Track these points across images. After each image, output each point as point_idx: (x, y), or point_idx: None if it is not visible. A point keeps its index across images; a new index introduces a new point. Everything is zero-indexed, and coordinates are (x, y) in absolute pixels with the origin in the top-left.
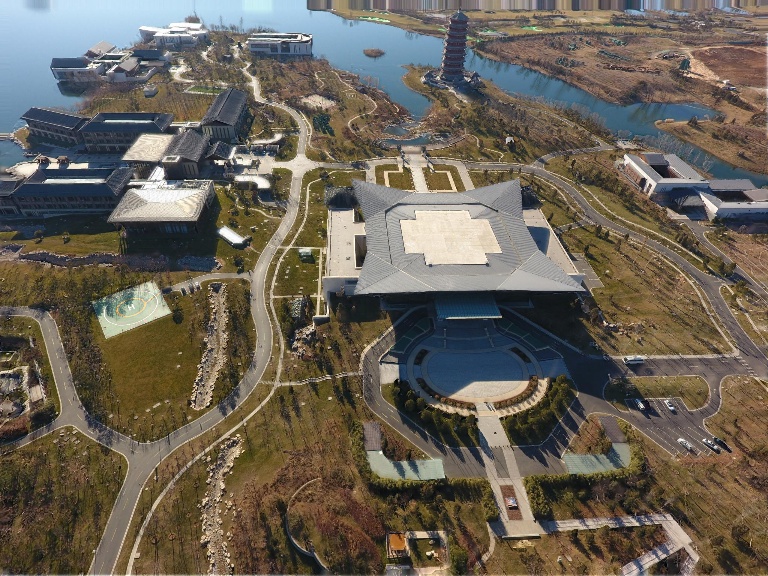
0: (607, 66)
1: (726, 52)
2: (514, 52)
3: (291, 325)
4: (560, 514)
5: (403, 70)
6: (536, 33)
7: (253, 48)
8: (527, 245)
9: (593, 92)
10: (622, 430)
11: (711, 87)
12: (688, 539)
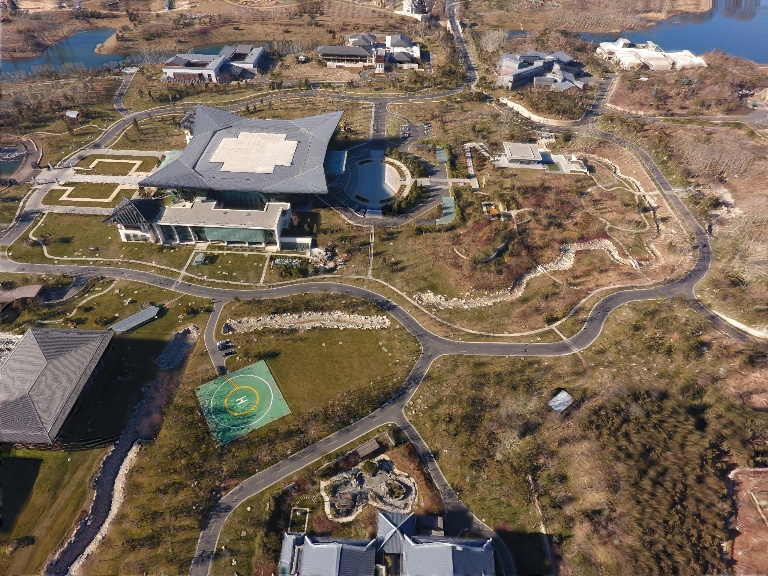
0: None
1: None
2: None
3: None
4: None
5: None
6: None
7: None
8: (282, 124)
9: None
10: (422, 143)
11: (66, 12)
12: (475, 143)
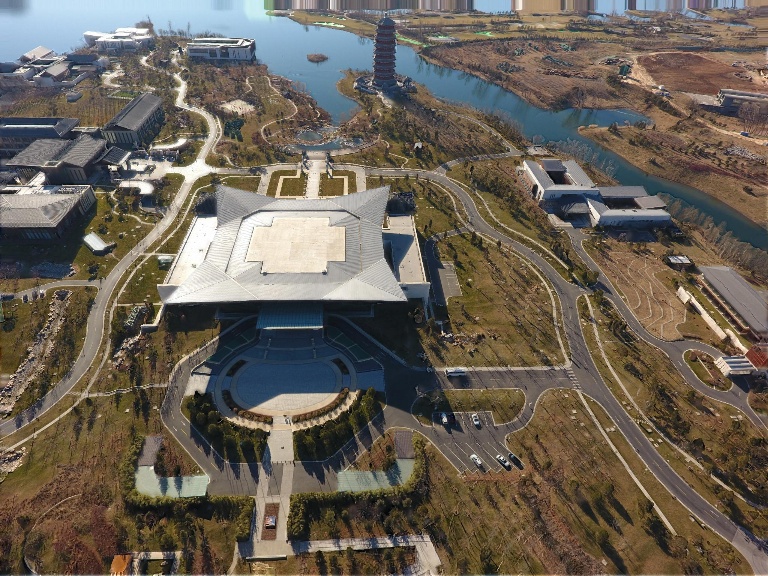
0: (547, 71)
1: (672, 58)
2: (458, 57)
3: (119, 334)
4: (317, 534)
5: (341, 75)
6: (486, 38)
7: (192, 53)
8: (374, 253)
9: (526, 97)
10: (413, 445)
11: (644, 93)
12: (437, 562)
